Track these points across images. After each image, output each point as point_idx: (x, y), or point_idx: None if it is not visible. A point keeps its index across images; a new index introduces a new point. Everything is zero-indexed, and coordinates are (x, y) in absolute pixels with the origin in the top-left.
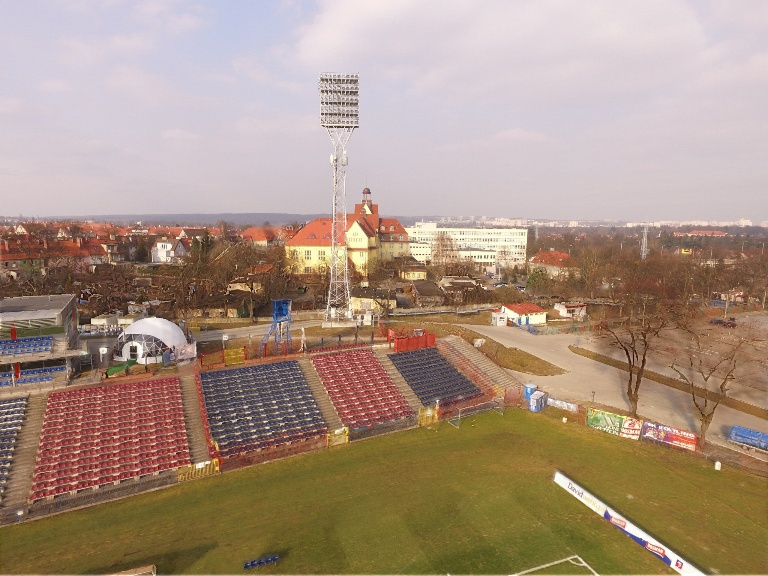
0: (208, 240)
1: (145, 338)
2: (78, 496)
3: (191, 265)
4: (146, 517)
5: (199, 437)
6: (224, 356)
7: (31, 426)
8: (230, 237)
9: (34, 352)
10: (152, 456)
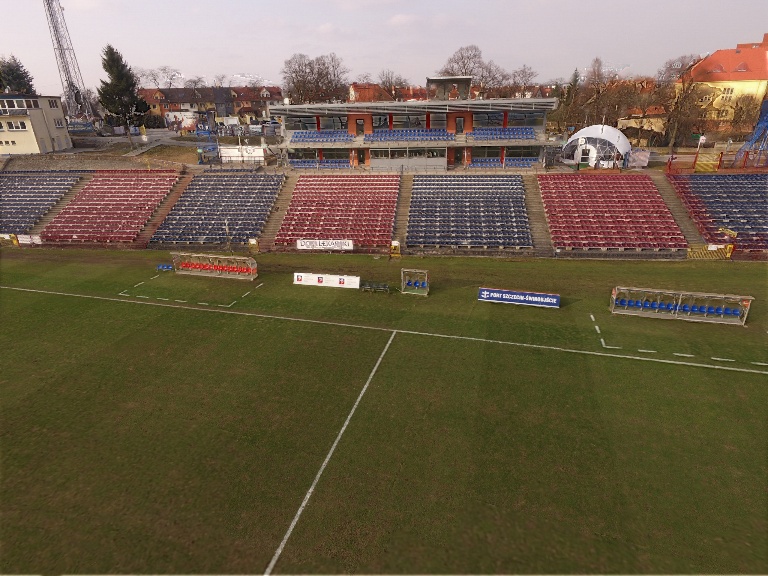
0: (576, 84)
1: (600, 141)
2: (591, 252)
3: (610, 86)
4: (675, 275)
5: (690, 229)
6: (696, 161)
7: (532, 196)
8: (603, 78)
9: (523, 138)
10: (648, 235)
